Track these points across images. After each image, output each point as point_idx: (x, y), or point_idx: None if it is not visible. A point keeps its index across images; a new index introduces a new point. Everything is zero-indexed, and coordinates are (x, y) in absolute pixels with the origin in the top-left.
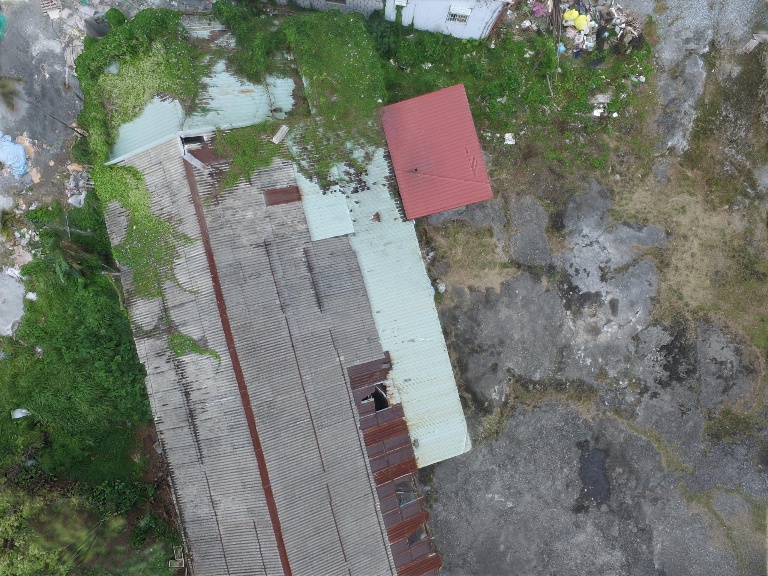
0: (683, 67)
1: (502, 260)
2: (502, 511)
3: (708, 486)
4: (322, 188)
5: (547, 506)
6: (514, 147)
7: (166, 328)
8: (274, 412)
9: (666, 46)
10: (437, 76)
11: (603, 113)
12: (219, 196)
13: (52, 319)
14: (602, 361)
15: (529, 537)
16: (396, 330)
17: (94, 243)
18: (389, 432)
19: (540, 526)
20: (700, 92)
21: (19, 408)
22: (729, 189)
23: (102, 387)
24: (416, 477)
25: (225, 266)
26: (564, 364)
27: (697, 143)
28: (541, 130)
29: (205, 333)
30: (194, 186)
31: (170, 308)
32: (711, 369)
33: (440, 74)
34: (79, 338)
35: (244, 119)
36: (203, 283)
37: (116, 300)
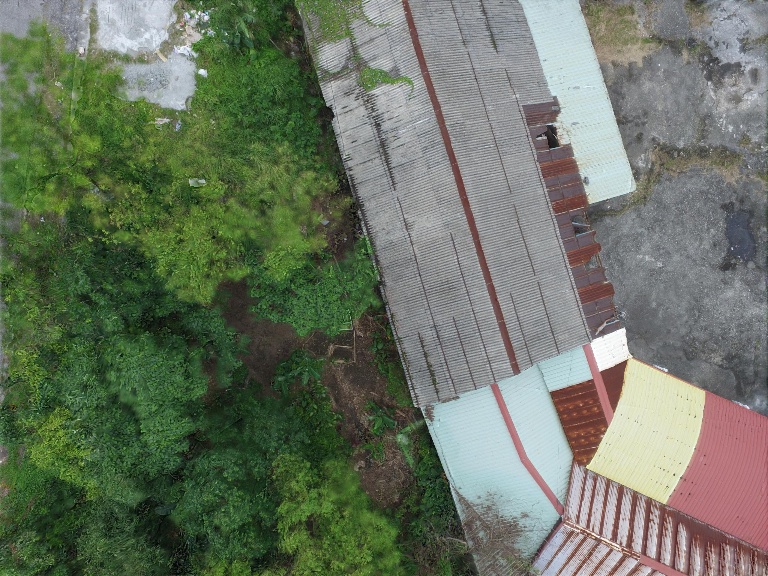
0: None
1: (644, 35)
2: (653, 270)
3: None
4: None
5: (696, 264)
6: None
7: (354, 67)
8: (465, 133)
9: None
10: None
11: None
12: None
13: (227, 88)
14: (743, 127)
15: (680, 294)
16: (562, 78)
17: (260, 23)
18: (562, 168)
19: (690, 283)
20: None
21: (196, 177)
22: None
23: (277, 152)
24: None
25: None
26: (707, 132)
27: None
28: None
29: (397, 63)
30: None
31: (359, 46)
32: None
33: None
34: (259, 99)
35: None
36: (394, 15)
37: None
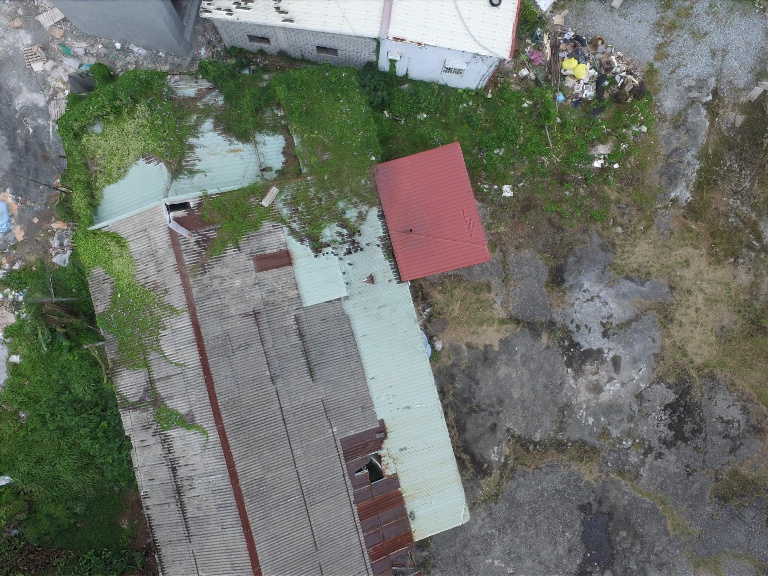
0: (686, 116)
1: (501, 316)
2: None
3: (715, 550)
4: (314, 251)
5: (549, 572)
6: (512, 199)
7: (152, 400)
8: (264, 490)
9: (668, 94)
10: (432, 128)
11: (604, 164)
12: (206, 264)
13: (36, 384)
14: (604, 420)
15: None
16: (391, 397)
17: (79, 303)
18: (384, 504)
19: None
20: (703, 141)
21: (2, 475)
22: (734, 242)
23: (88, 454)
24: None
25: (212, 338)
26: (565, 424)
27: (701, 194)
28: (540, 182)
29: (192, 408)
30: (180, 255)
31: (156, 380)
32: (717, 428)
33: (435, 125)
34: (63, 406)
35: (233, 180)
36: (190, 356)
37: None
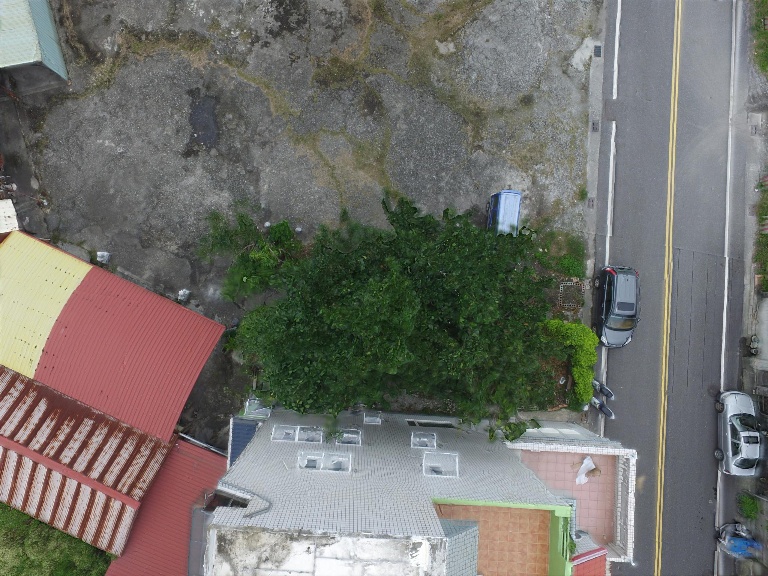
0: None
1: None
2: (112, 156)
3: (315, 129)
4: None
5: (157, 150)
6: None
7: None
8: None
9: None
10: None
11: None
12: None
13: None
14: (214, 12)
15: (139, 180)
16: None
17: None
18: None
19: (150, 170)
20: None
21: None
22: None
23: None
24: (26, 124)
25: None
26: (177, 15)
27: None
28: None
29: None
30: None
31: None
32: (321, 19)
33: None
34: None
35: None
36: None
37: None
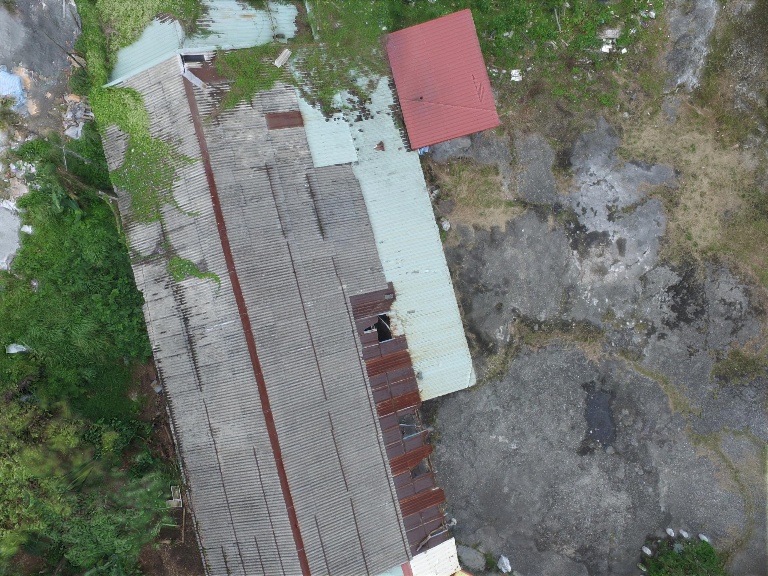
0: (693, 3)
1: (508, 198)
2: (506, 453)
3: (716, 428)
4: (325, 115)
5: (552, 448)
6: (521, 84)
7: (164, 253)
8: (275, 337)
9: None
10: (443, 9)
11: (612, 49)
12: (220, 117)
13: (48, 251)
14: (609, 301)
15: (533, 479)
16: (400, 261)
17: (91, 176)
18: (392, 363)
19: (545, 468)
20: (710, 29)
21: (14, 343)
22: (739, 128)
23: (99, 321)
24: None
25: (225, 187)
26: (570, 304)
27: (707, 81)
28: (548, 66)
29: (205, 256)
30: (194, 105)
31: (169, 232)
32: (720, 310)
33: (446, 8)
34: (75, 269)
35: (245, 43)
36: (203, 205)
37: (113, 233)
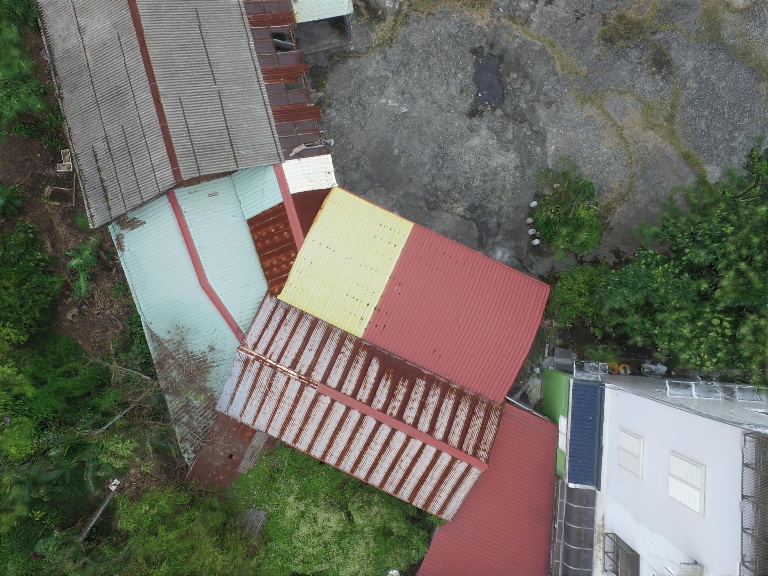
0: None
1: None
2: (396, 116)
3: (602, 88)
4: None
5: (441, 110)
6: None
7: None
8: None
9: None
10: None
11: None
12: None
13: None
14: None
15: (423, 141)
16: None
17: None
18: None
19: (434, 130)
20: None
21: None
22: None
23: None
24: (309, 83)
25: None
26: None
27: None
28: None
29: None
30: None
31: None
32: None
33: None
34: None
35: None
36: None
37: None
